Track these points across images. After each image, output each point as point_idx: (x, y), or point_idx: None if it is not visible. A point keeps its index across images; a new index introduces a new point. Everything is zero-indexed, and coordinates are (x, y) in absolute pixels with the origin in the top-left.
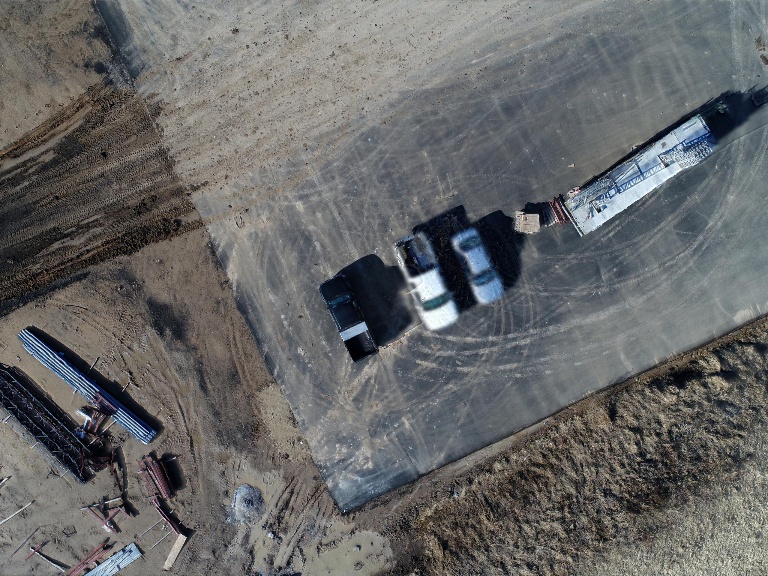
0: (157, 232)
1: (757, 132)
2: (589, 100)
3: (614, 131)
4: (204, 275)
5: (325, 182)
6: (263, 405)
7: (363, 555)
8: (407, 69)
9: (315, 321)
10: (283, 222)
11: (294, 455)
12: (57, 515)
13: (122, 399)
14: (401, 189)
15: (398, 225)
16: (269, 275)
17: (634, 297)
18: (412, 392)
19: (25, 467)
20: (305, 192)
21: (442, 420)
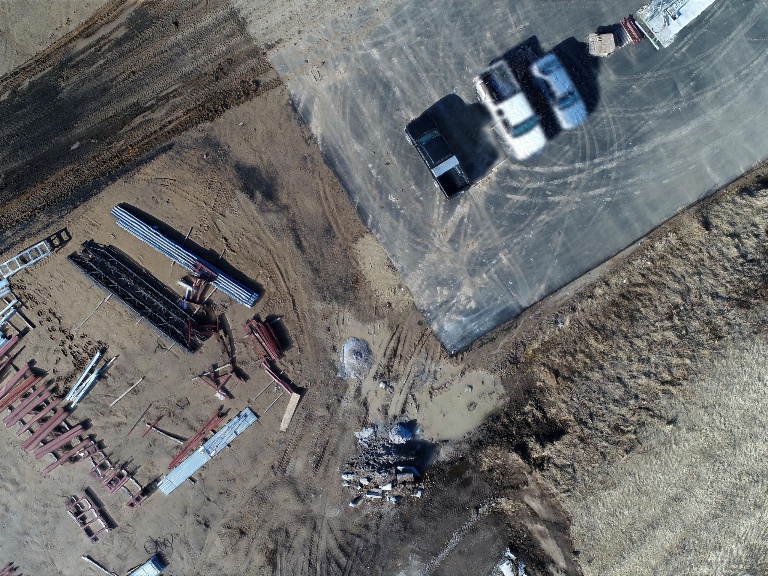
0: (237, 95)
1: None
2: None
3: None
4: (288, 133)
5: (397, 27)
6: (360, 256)
7: (475, 395)
8: None
9: (403, 167)
10: (360, 71)
11: (396, 303)
12: (169, 388)
13: (220, 266)
14: (473, 26)
15: (474, 62)
16: (352, 126)
17: (713, 109)
18: (506, 227)
19: (132, 344)
20: (379, 39)
21: (538, 252)
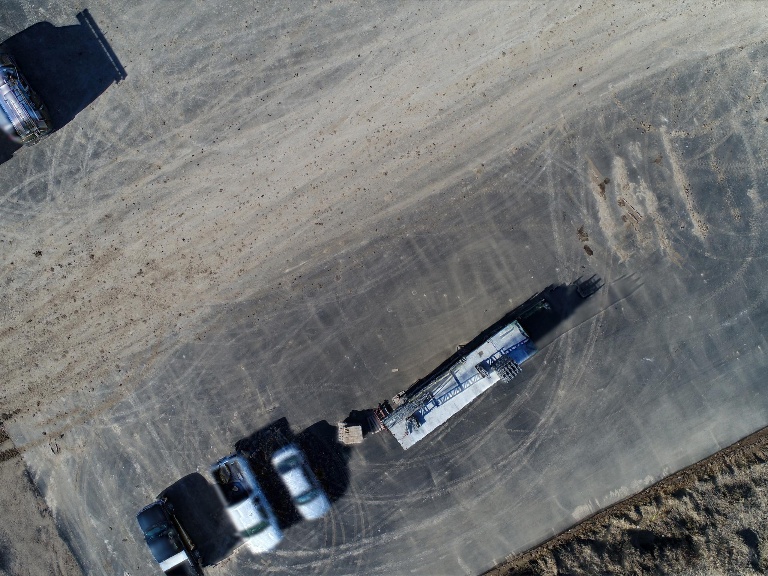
0: None
1: (585, 324)
2: (409, 302)
3: (437, 332)
4: (23, 504)
5: (141, 402)
6: None
7: None
8: (219, 282)
9: (140, 544)
10: (100, 446)
11: None
12: None
13: None
14: (220, 405)
15: (219, 441)
16: (89, 500)
17: (468, 499)
18: None
19: None
20: (121, 414)
21: None
